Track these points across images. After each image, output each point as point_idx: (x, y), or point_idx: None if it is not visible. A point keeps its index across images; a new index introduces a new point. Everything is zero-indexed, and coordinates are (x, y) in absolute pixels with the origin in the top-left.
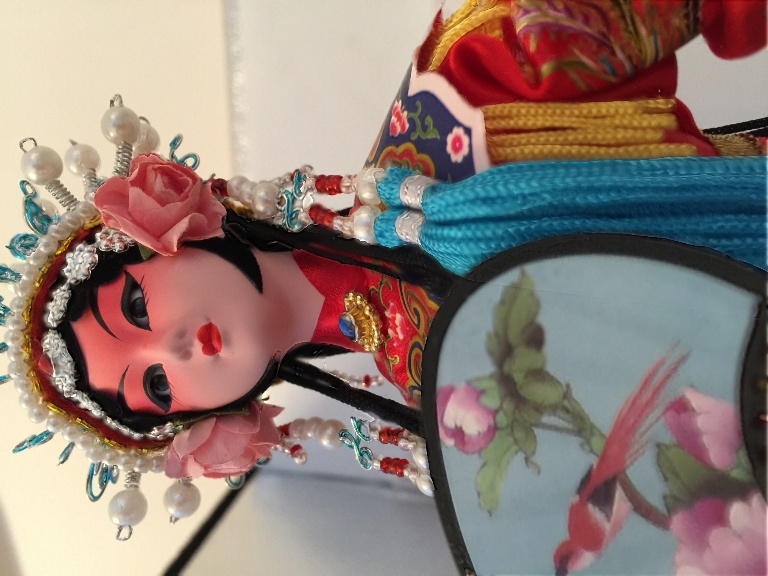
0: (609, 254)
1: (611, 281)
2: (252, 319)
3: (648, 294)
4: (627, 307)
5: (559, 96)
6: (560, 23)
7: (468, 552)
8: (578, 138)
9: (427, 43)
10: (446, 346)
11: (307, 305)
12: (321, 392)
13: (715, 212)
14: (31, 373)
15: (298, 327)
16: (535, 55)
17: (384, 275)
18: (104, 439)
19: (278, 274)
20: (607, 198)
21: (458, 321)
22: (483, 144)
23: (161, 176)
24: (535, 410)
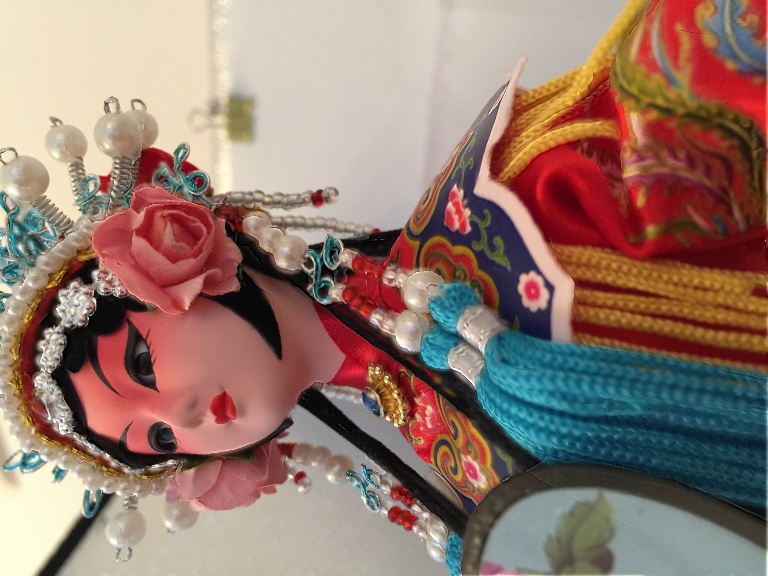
0: (706, 519)
1: (702, 544)
2: (270, 390)
3: (742, 573)
4: (714, 574)
5: (659, 256)
6: (677, 174)
7: None
8: (673, 310)
9: (505, 136)
10: (498, 527)
11: (326, 360)
12: None
13: None
14: (22, 407)
15: (313, 377)
16: (642, 211)
17: None
18: (102, 467)
19: (296, 324)
20: (705, 425)
21: (516, 511)
22: (567, 312)
23: (171, 226)
24: None
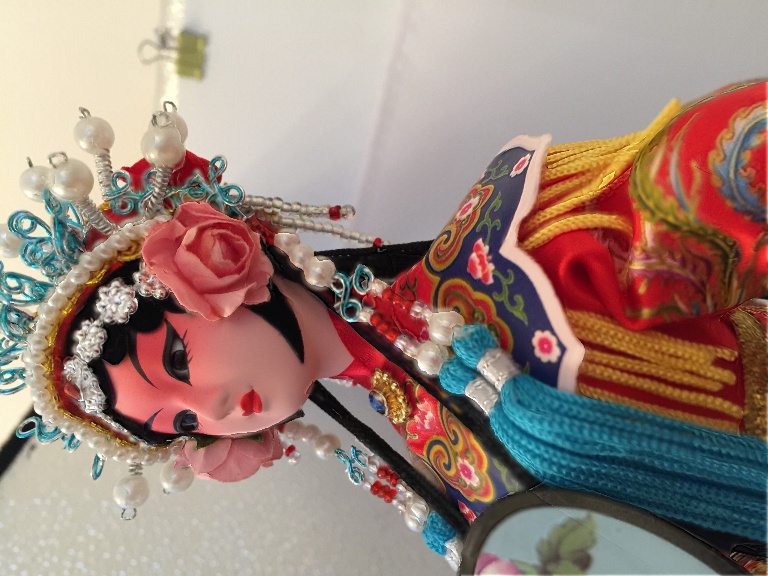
0: (667, 540)
1: (661, 557)
2: (293, 390)
3: None
4: None
5: (647, 329)
6: (672, 270)
7: None
8: (651, 371)
9: None
10: (500, 529)
11: (335, 361)
12: None
13: (747, 499)
14: (50, 387)
15: (321, 372)
16: (642, 296)
17: None
18: (116, 439)
19: (312, 329)
20: (671, 468)
21: (517, 518)
22: (574, 370)
23: (220, 244)
24: None
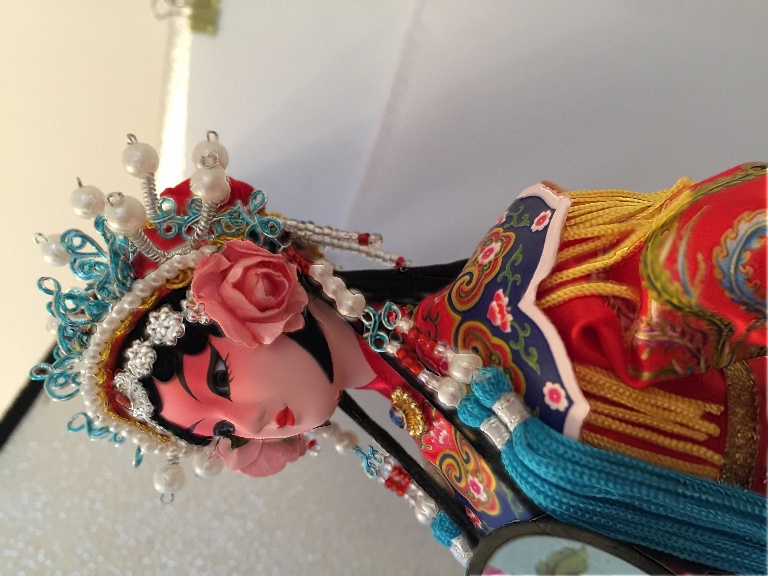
0: (648, 574)
1: None
2: (322, 407)
3: None
4: None
5: (646, 386)
6: (672, 340)
7: None
8: (646, 422)
9: None
10: (505, 548)
11: (360, 376)
12: None
13: (720, 538)
14: (102, 394)
15: None
16: (643, 361)
17: None
18: (157, 435)
19: (340, 348)
20: (656, 511)
21: (521, 542)
22: (579, 421)
23: (263, 282)
24: None
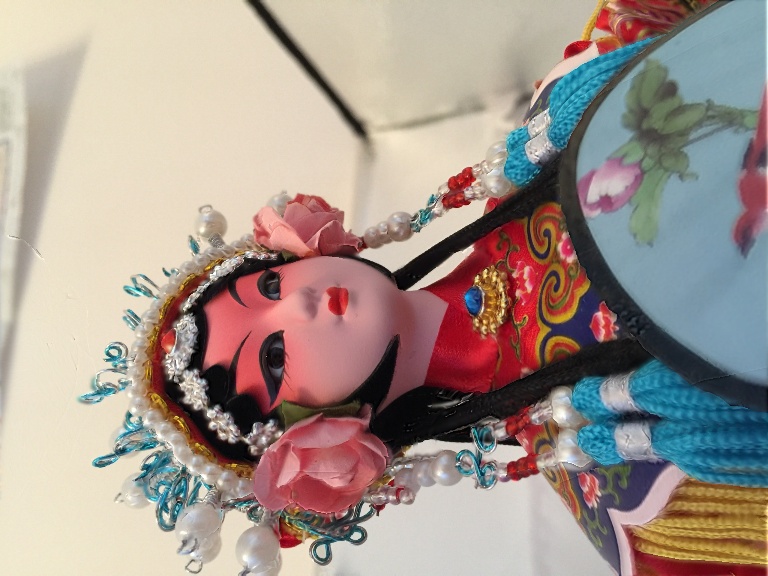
0: (720, 7)
1: (727, 19)
2: (380, 287)
3: (762, 7)
4: (747, 24)
5: None
6: (648, 19)
7: (632, 297)
8: None
9: None
10: (583, 148)
11: (430, 312)
12: (435, 431)
13: None
14: (148, 362)
15: (419, 339)
16: (632, 30)
17: (511, 243)
18: (195, 443)
19: None
20: None
21: (592, 125)
22: None
23: None
24: (681, 136)
